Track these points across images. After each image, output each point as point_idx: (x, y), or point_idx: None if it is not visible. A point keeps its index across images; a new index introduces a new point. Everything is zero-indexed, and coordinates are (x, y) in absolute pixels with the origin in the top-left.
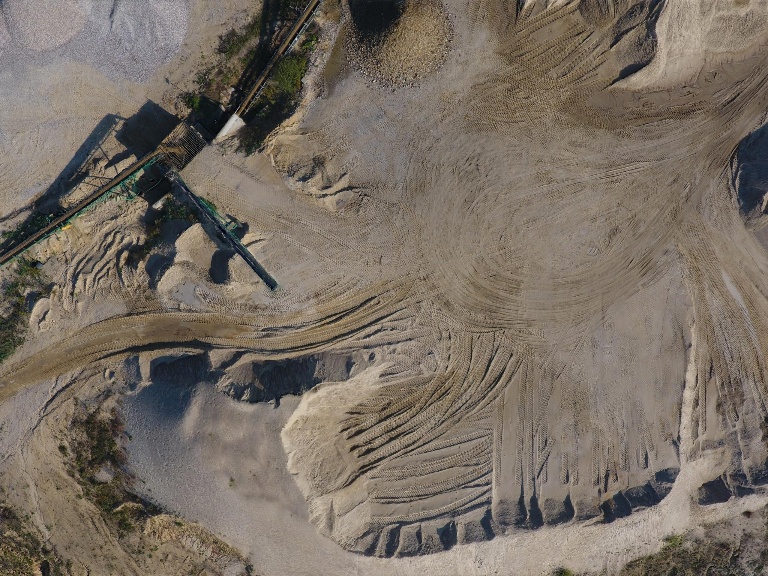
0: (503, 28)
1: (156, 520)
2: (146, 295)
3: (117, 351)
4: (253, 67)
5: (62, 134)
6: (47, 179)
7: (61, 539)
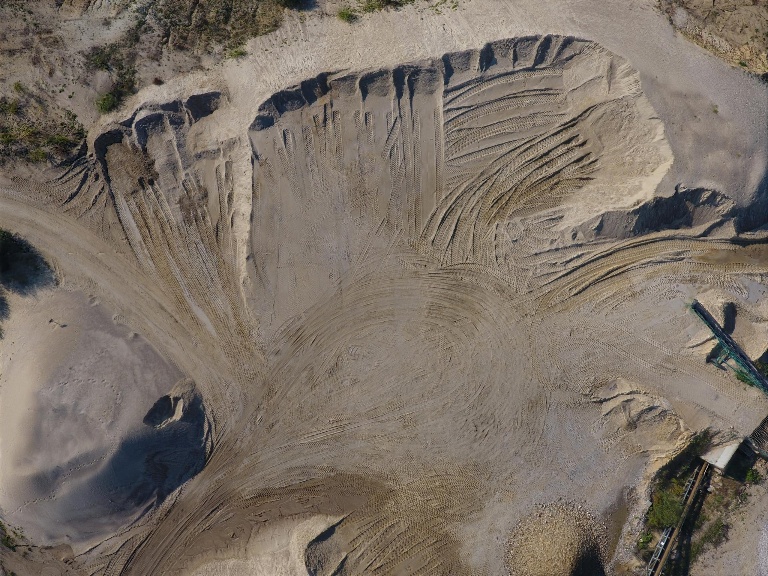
0: (455, 568)
1: (763, 68)
2: None
3: None
4: (693, 513)
5: None
6: None
7: None
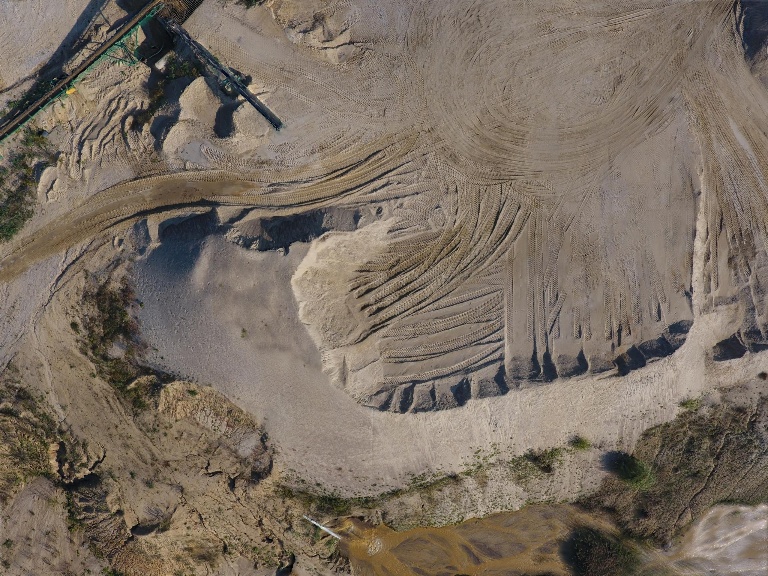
0: None
1: (170, 390)
2: (152, 158)
3: (125, 217)
4: None
5: (63, 1)
6: (50, 47)
7: (76, 419)
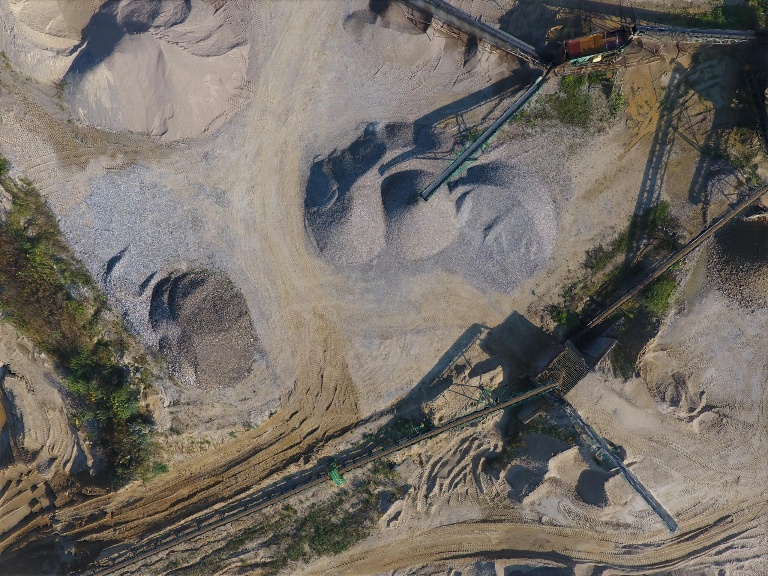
0: None
1: None
2: (504, 504)
3: (466, 554)
4: (612, 280)
5: (428, 341)
6: (409, 384)
7: None
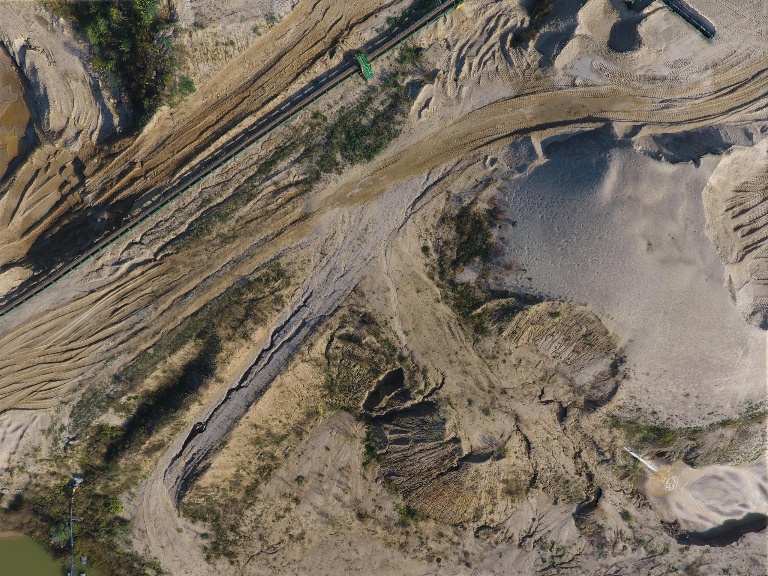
0: None
1: (529, 313)
2: (536, 74)
3: (501, 136)
4: None
5: None
6: None
7: (418, 344)
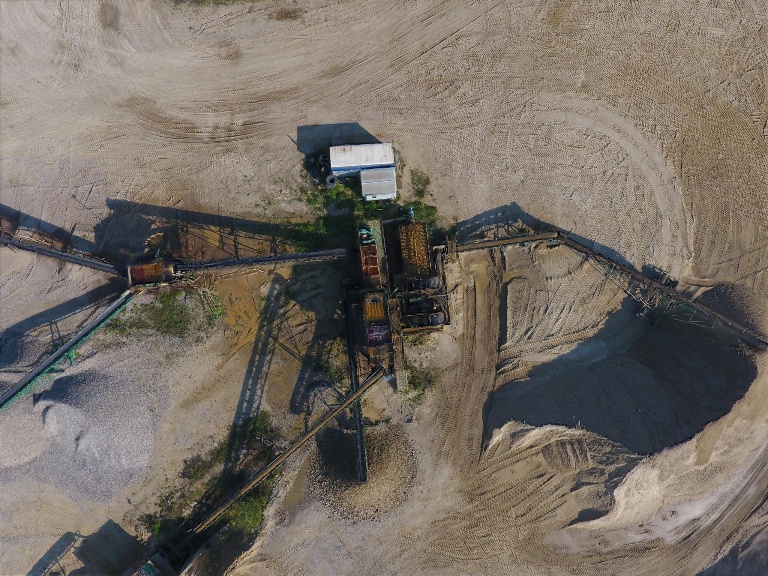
0: (466, 466)
1: None
2: None
3: None
4: (217, 486)
5: (20, 549)
6: None
7: None
